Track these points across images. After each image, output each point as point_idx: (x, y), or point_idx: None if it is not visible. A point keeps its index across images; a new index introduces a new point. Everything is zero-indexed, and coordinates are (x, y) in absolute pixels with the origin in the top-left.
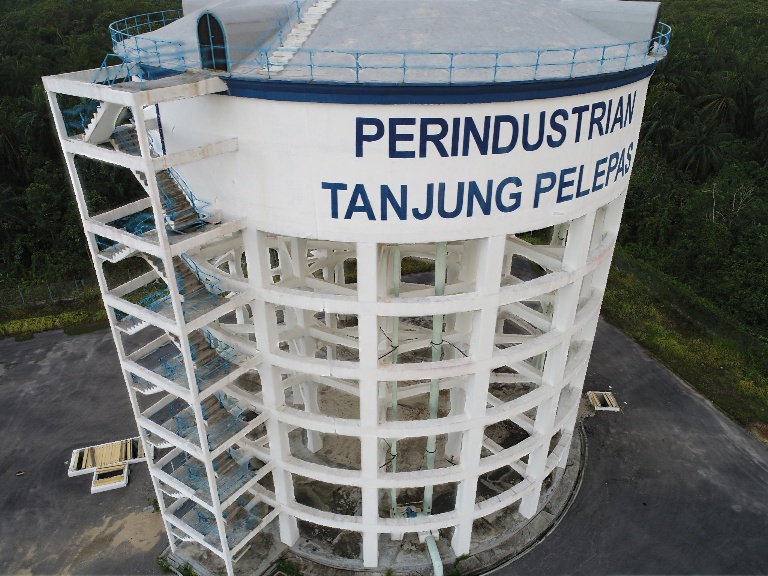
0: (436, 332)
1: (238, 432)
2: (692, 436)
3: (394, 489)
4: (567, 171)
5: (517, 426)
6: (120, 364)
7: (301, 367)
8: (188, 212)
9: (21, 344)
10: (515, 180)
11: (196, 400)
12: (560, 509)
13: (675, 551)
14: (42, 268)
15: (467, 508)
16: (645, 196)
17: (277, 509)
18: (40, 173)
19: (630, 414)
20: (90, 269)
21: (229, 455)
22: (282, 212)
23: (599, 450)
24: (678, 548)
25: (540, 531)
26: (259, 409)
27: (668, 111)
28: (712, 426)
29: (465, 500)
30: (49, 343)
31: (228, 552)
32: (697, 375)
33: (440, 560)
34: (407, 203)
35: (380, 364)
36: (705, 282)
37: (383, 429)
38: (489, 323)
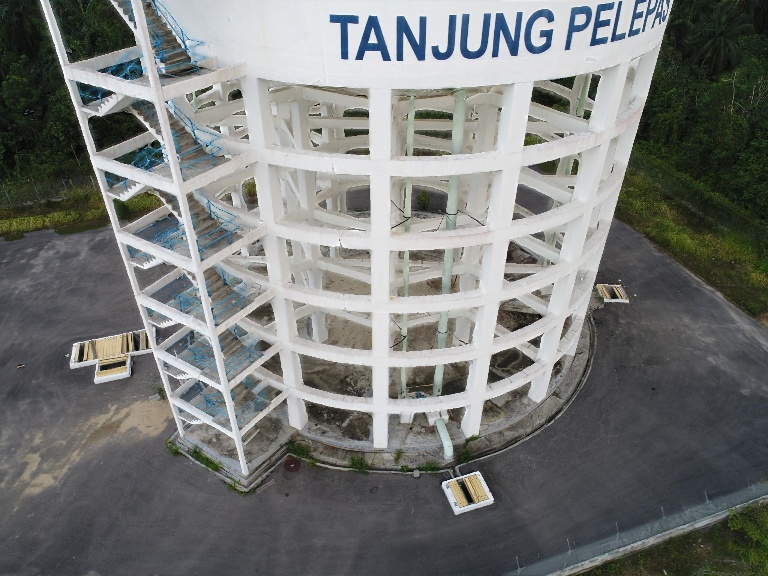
0: (451, 201)
1: (244, 308)
2: (702, 326)
3: (404, 372)
4: (604, 7)
5: (525, 317)
6: (116, 262)
7: (308, 237)
8: (180, 55)
9: (11, 243)
10: (547, 14)
11: (199, 269)
12: (569, 394)
13: (683, 431)
14: (27, 168)
15: (479, 388)
16: (659, 90)
17: (285, 392)
18: (16, 68)
19: (640, 306)
20: (77, 169)
21: (235, 336)
22: (285, 54)
23: (608, 339)
24: (686, 428)
25: (549, 414)
26: (264, 287)
27: (685, 4)
28: (722, 316)
29: (477, 380)
30: (40, 242)
31: (238, 431)
32: (708, 269)
33: (450, 440)
34: (426, 39)
35: (393, 233)
36: (718, 178)
37: (395, 304)
38: (510, 186)
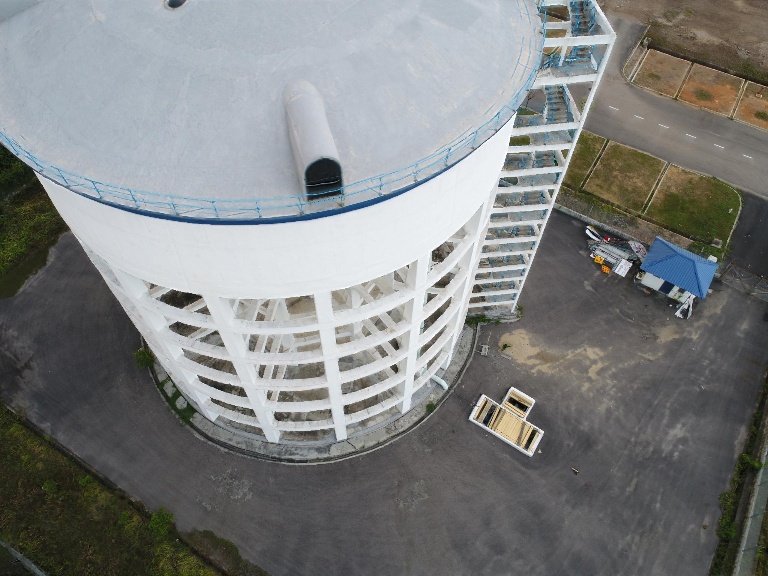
0: None
1: None
2: None
3: None
4: None
5: None
6: (438, 565)
7: None
8: None
9: None
10: None
11: None
12: None
13: None
14: None
15: None
16: None
17: None
18: None
19: None
20: None
21: None
22: None
23: None
24: None
25: None
26: None
27: None
28: None
29: None
30: None
31: None
32: None
33: None
34: None
35: None
36: None
37: None
38: None
